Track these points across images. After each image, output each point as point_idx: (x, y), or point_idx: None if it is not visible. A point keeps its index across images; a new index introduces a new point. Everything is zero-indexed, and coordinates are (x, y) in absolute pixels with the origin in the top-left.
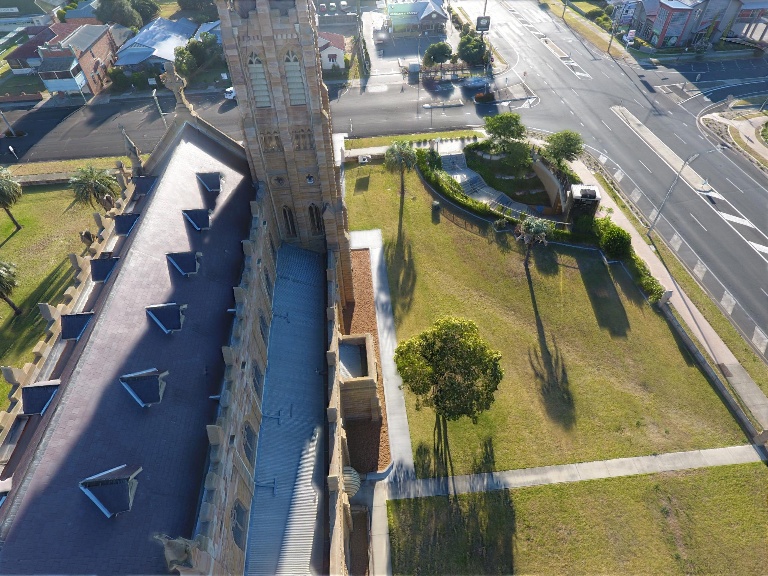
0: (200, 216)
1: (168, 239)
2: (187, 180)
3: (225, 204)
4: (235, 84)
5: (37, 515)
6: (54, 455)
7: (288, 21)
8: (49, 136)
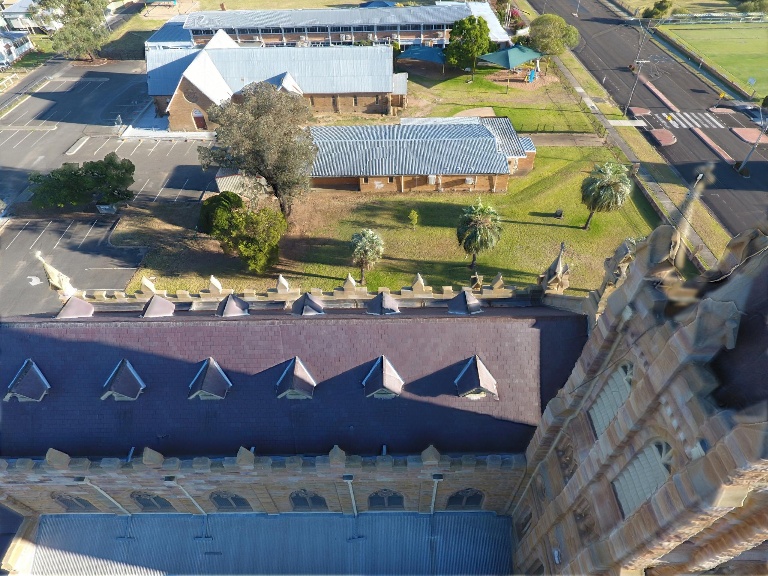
0: (376, 380)
1: (321, 353)
2: (450, 348)
3: (447, 409)
4: (581, 358)
5: (3, 340)
6: (45, 334)
7: (702, 421)
8: (757, 194)
